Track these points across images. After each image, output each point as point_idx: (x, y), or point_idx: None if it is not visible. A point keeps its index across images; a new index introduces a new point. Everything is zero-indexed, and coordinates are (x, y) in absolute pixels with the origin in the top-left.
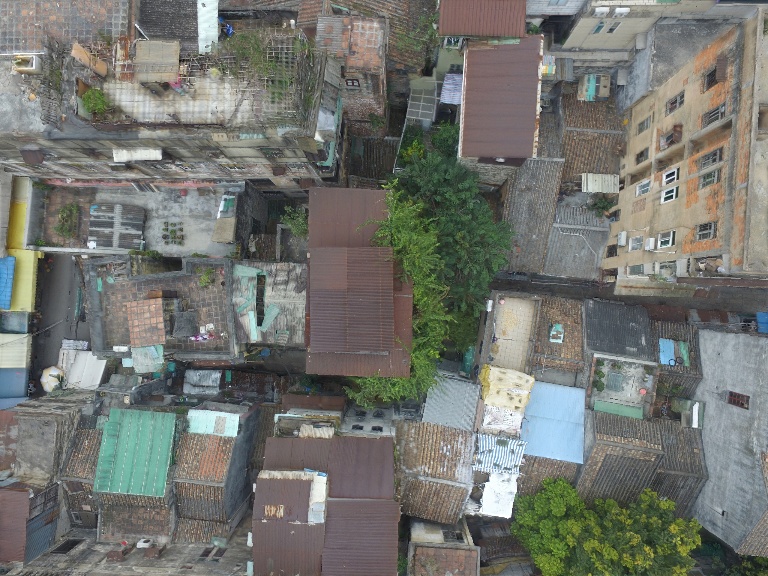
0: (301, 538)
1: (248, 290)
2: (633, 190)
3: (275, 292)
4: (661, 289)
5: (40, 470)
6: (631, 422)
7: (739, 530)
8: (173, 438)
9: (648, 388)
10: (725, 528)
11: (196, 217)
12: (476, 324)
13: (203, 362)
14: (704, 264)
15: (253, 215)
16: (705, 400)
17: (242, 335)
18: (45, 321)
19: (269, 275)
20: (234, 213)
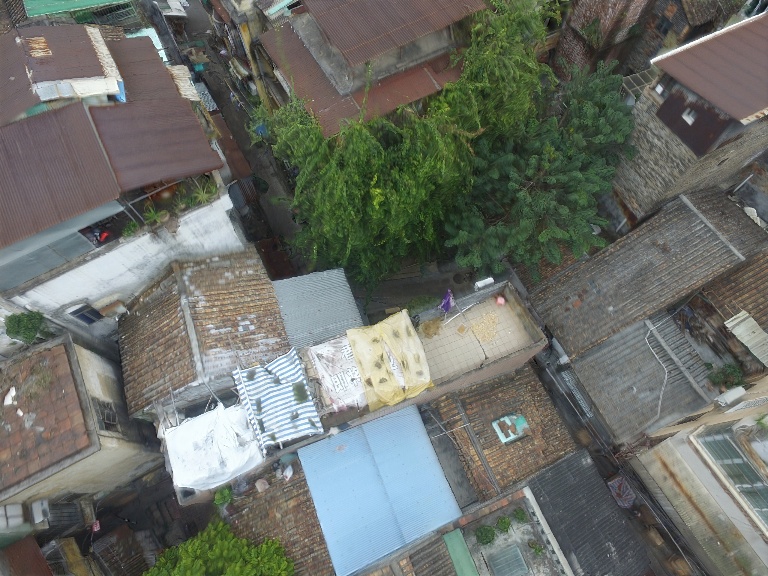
0: (6, 94)
1: None
2: None
3: None
4: (712, 531)
5: None
6: None
7: None
8: (109, 5)
9: None
10: None
11: None
12: None
13: (215, 0)
14: None
15: None
16: None
17: (268, 1)
18: None
19: None
20: None
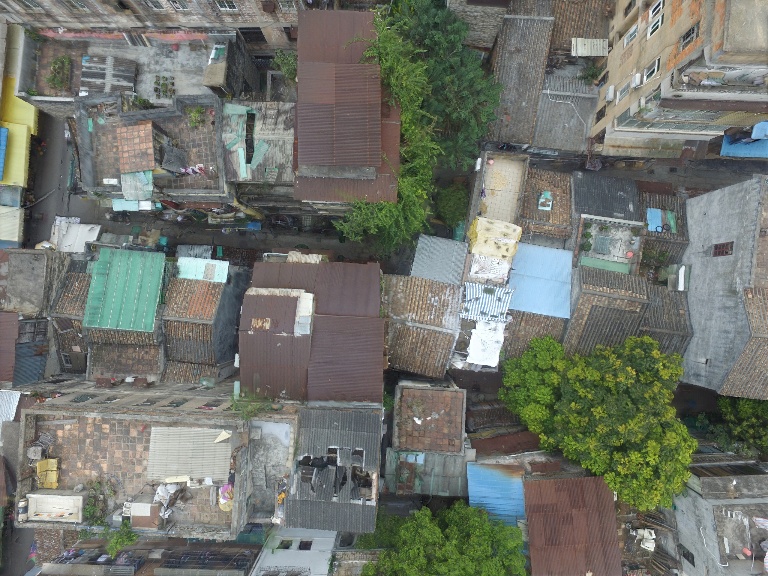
0: (287, 351)
1: (238, 127)
2: (621, 44)
3: (264, 129)
4: (648, 149)
5: (30, 304)
6: (617, 276)
7: (722, 371)
8: (162, 277)
9: (635, 250)
10: (708, 374)
11: (187, 72)
12: (466, 199)
13: (193, 204)
14: (687, 78)
15: (244, 75)
16: (691, 263)
17: (231, 173)
18: (38, 204)
19: (259, 113)
20: (225, 58)
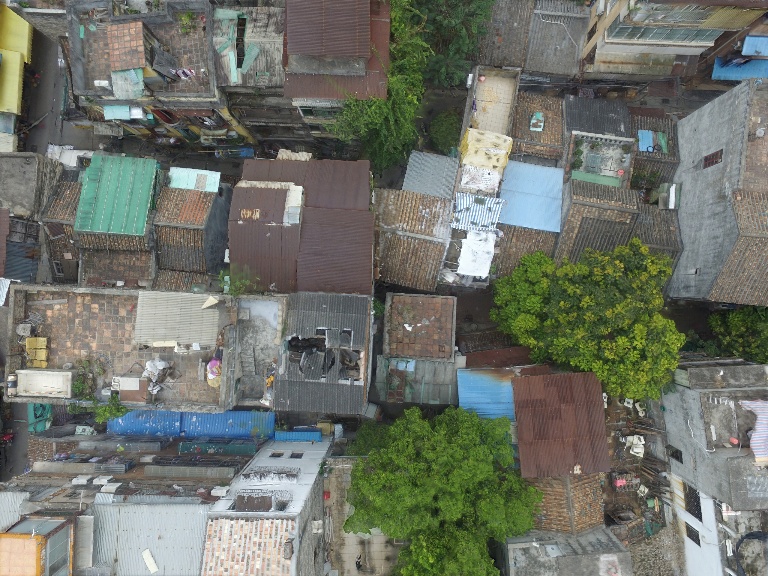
0: (277, 242)
1: (229, 31)
2: None
3: (255, 33)
4: (639, 65)
5: (21, 208)
6: (607, 188)
7: (711, 276)
8: (154, 182)
9: (626, 167)
10: (698, 283)
11: None
12: (458, 124)
13: (184, 112)
14: None
15: None
16: (682, 181)
17: (222, 78)
18: (32, 137)
19: (250, 18)
20: None
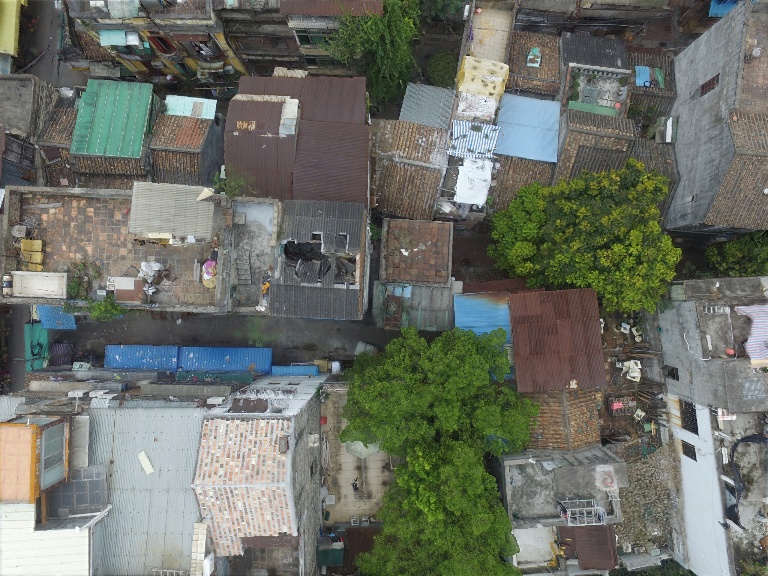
0: (272, 154)
1: None
2: None
3: None
4: None
5: (17, 130)
6: (604, 118)
7: (707, 199)
8: (150, 106)
9: (622, 100)
10: (694, 209)
11: None
12: (455, 64)
13: (180, 37)
14: None
15: None
16: (679, 114)
17: (218, 0)
18: None
19: None
20: None
